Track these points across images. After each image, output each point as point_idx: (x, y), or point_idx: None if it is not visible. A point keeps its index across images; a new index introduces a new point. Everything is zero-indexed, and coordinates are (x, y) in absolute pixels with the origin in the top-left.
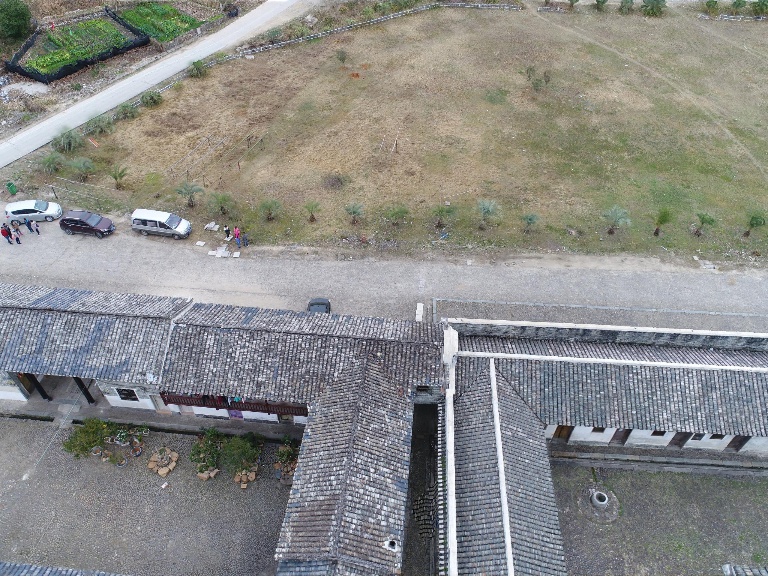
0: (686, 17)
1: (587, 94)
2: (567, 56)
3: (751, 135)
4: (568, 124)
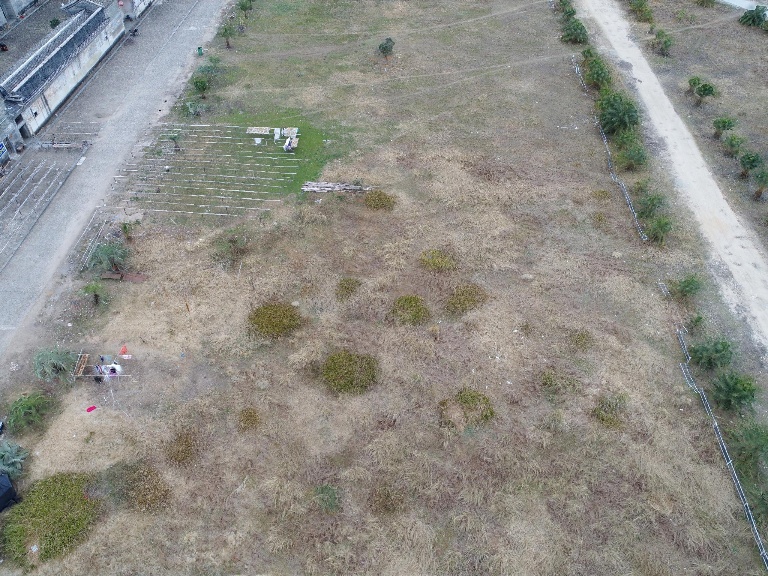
0: (573, 54)
1: (402, 2)
2: (463, 3)
3: (349, 39)
4: None
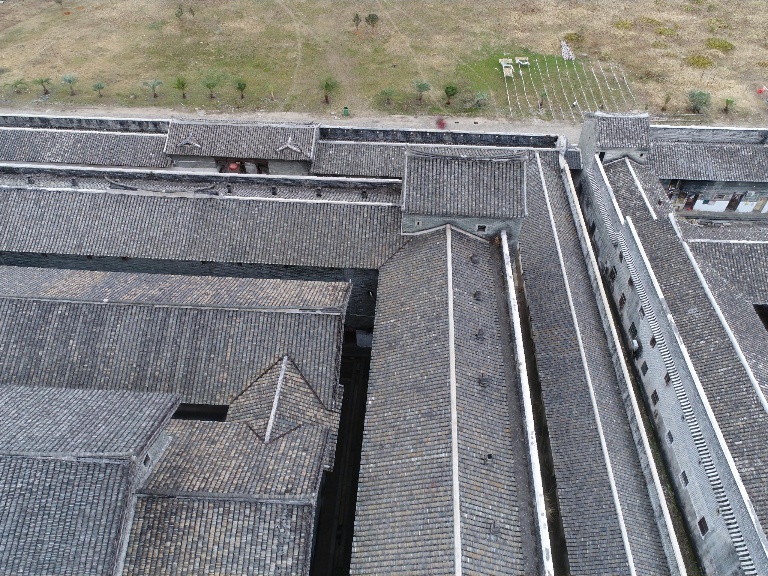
0: None
1: (224, 24)
2: (235, 1)
3: (313, 47)
4: (192, 41)
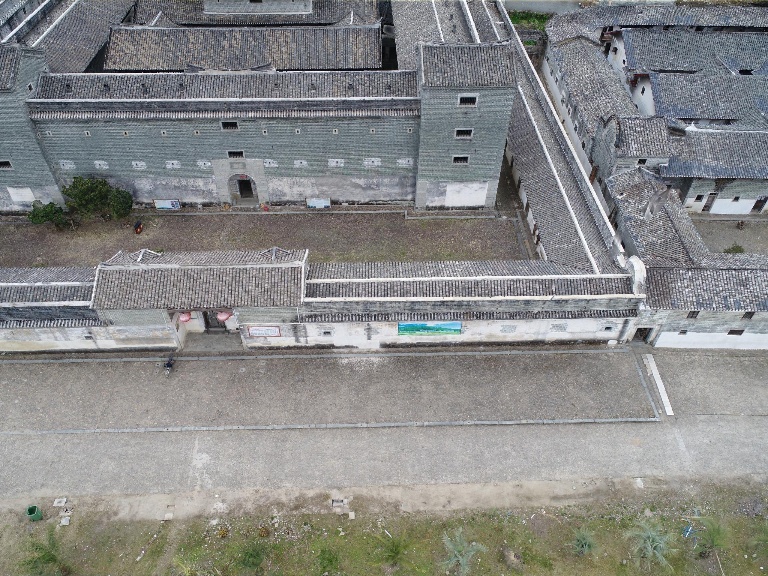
0: None
1: None
2: None
3: None
4: None
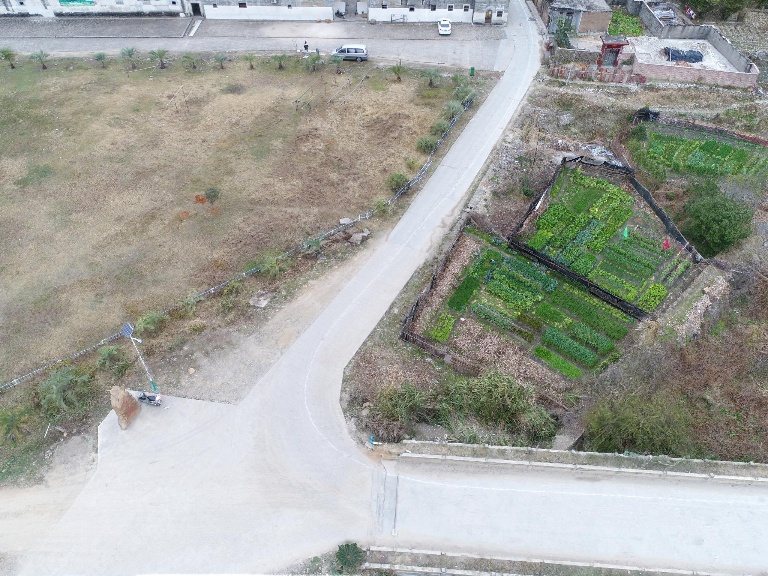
0: None
1: None
2: None
3: None
4: None
